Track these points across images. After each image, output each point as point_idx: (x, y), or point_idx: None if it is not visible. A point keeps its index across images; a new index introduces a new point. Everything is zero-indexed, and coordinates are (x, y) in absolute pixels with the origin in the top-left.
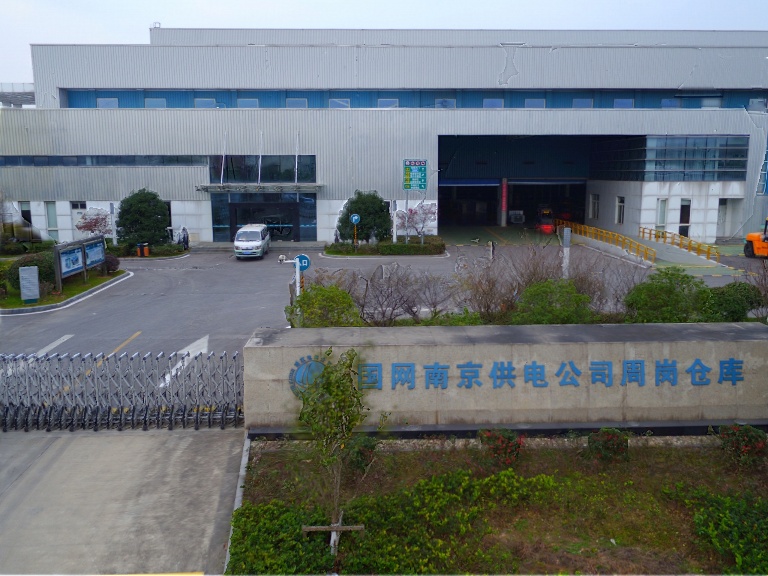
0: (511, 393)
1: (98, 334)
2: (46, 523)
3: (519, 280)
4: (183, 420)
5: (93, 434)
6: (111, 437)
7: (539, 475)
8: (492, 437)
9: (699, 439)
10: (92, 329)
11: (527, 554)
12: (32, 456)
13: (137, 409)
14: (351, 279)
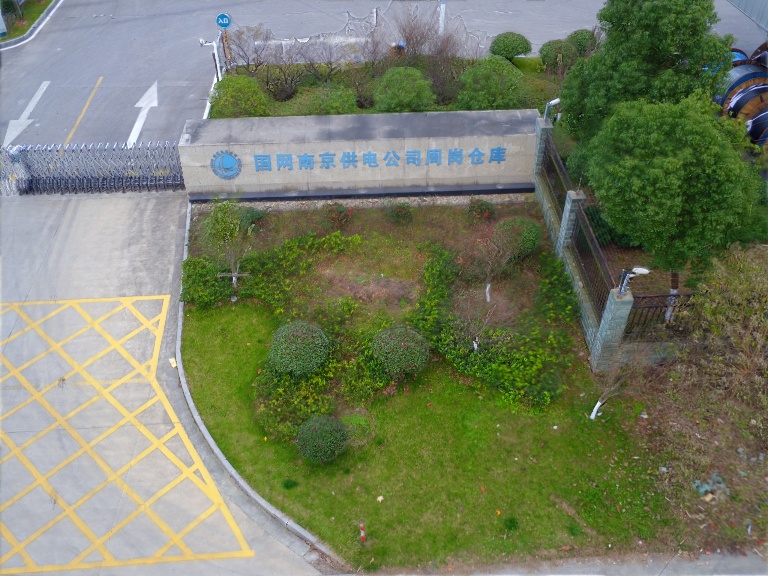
0: (355, 171)
1: (69, 81)
2: (82, 266)
3: (400, 37)
4: (147, 186)
5: (91, 197)
6: (104, 199)
7: (354, 235)
8: (332, 210)
9: (470, 198)
10: (62, 73)
11: (335, 283)
12: (58, 216)
13: (116, 179)
14: (265, 36)
